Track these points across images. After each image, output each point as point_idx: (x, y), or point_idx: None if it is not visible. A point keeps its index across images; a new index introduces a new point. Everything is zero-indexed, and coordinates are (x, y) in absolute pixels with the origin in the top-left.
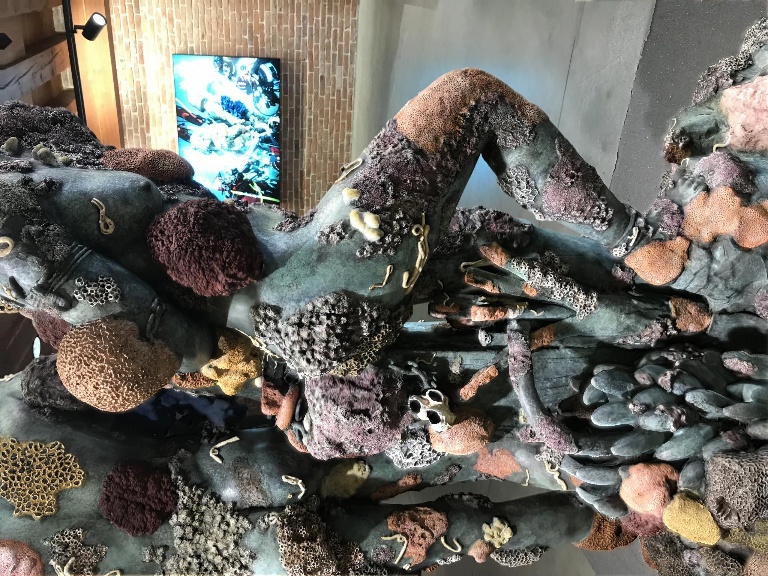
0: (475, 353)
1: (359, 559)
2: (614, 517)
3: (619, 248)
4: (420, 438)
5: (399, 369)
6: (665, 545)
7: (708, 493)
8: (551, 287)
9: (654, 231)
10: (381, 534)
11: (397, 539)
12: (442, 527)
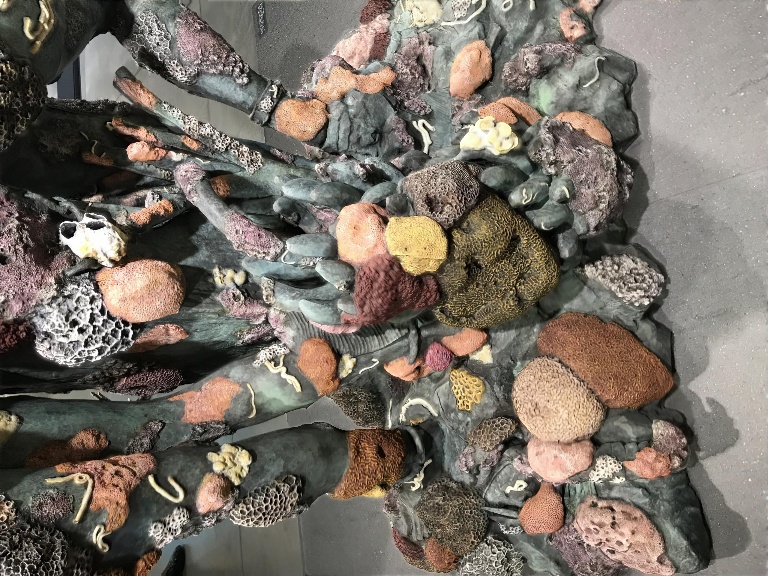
0: (143, 208)
1: (6, 512)
2: (344, 282)
3: (265, 100)
4: (84, 284)
5: (40, 197)
6: (442, 494)
7: (416, 203)
8: (211, 135)
9: (292, 95)
10: (45, 476)
11: (74, 480)
12: (147, 463)
